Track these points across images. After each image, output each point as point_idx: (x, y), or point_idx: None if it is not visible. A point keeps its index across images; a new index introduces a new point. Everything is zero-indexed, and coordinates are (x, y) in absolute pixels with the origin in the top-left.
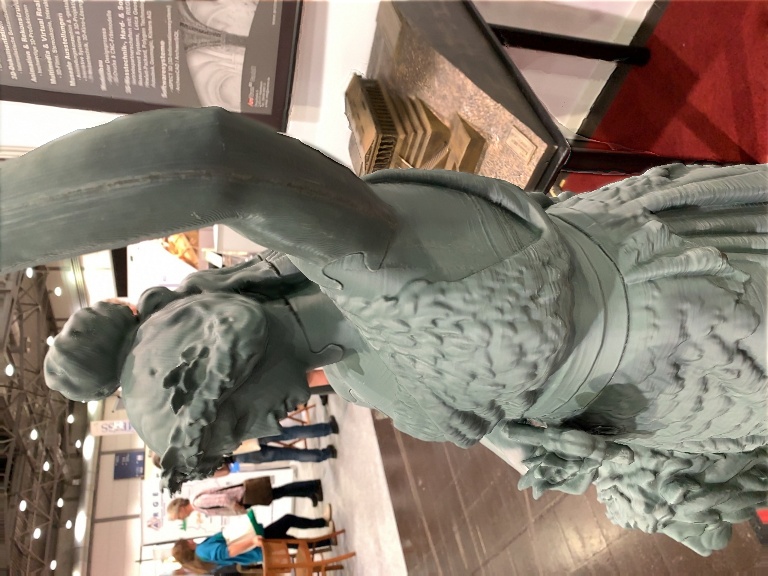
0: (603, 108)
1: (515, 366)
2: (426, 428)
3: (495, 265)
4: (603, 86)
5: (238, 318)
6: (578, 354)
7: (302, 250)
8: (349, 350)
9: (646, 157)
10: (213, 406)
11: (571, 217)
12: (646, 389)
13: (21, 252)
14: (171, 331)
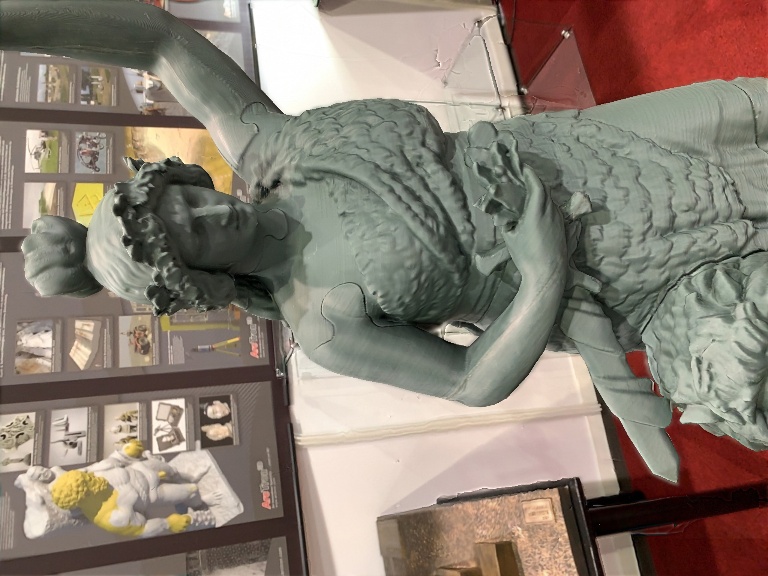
0: (651, 571)
1: (394, 111)
2: (377, 226)
3: None
4: (634, 553)
5: None
6: (461, 143)
7: (218, 80)
8: (292, 220)
9: (676, 498)
10: (164, 165)
11: None
12: (538, 151)
13: (53, 5)
14: None
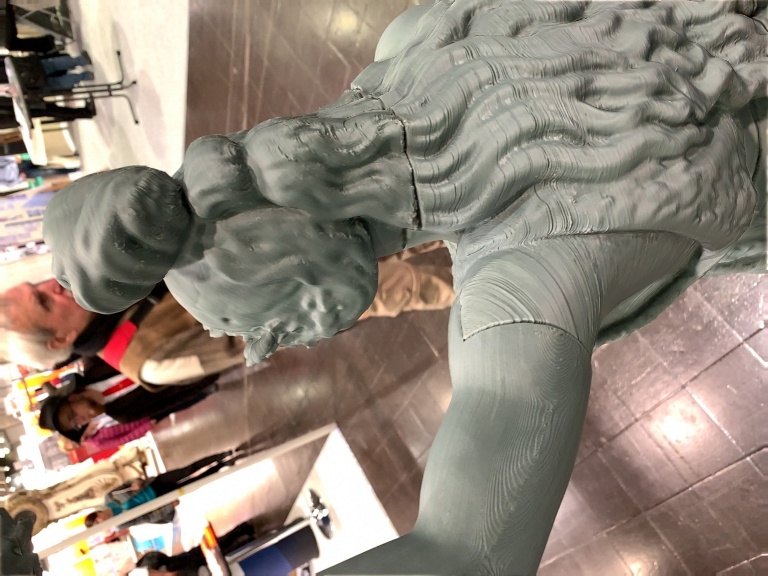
0: None
1: None
2: None
3: (610, 338)
4: None
5: (348, 307)
6: None
7: None
8: None
9: None
10: None
11: (760, 185)
12: None
13: None
14: (258, 294)
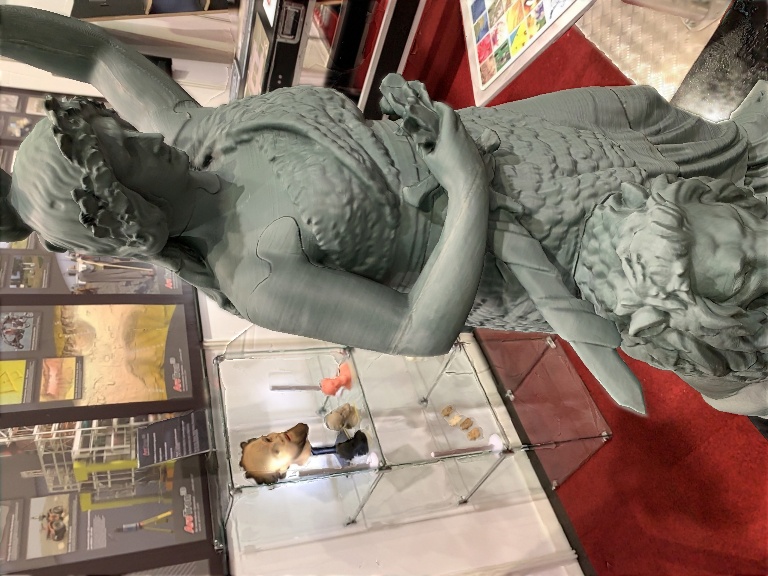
0: None
1: None
2: None
3: None
4: None
5: None
6: None
7: (152, 79)
8: (224, 181)
9: None
10: None
11: None
12: None
13: None
14: None
